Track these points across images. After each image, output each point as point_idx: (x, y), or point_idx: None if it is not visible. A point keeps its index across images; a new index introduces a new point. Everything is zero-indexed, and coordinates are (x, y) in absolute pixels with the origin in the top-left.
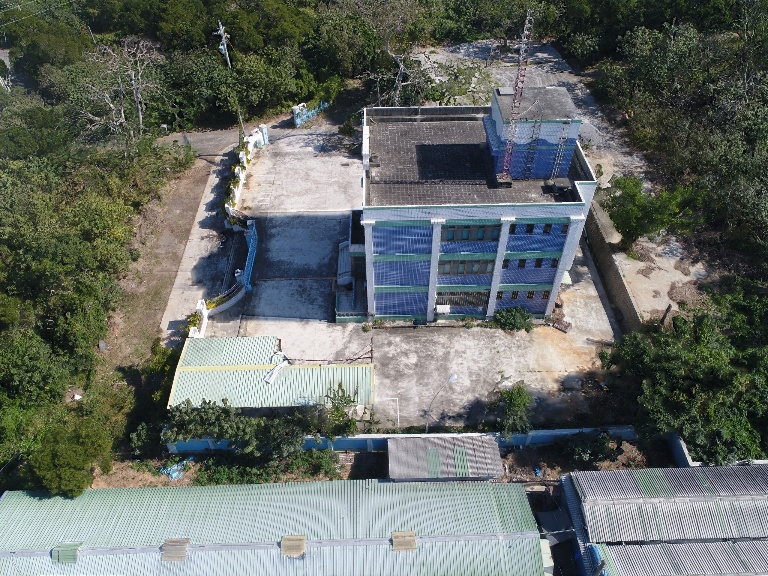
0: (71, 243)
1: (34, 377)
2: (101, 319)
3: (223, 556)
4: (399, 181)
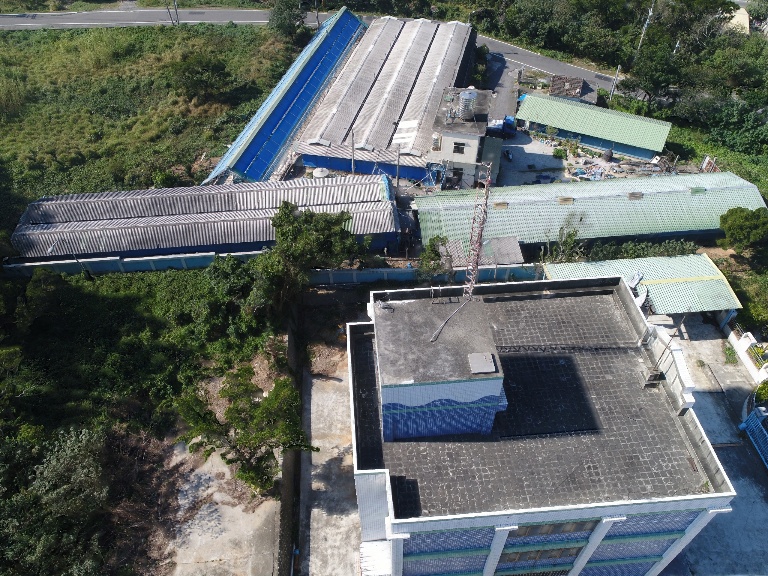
0: None
1: None
2: None
3: None
4: (600, 348)
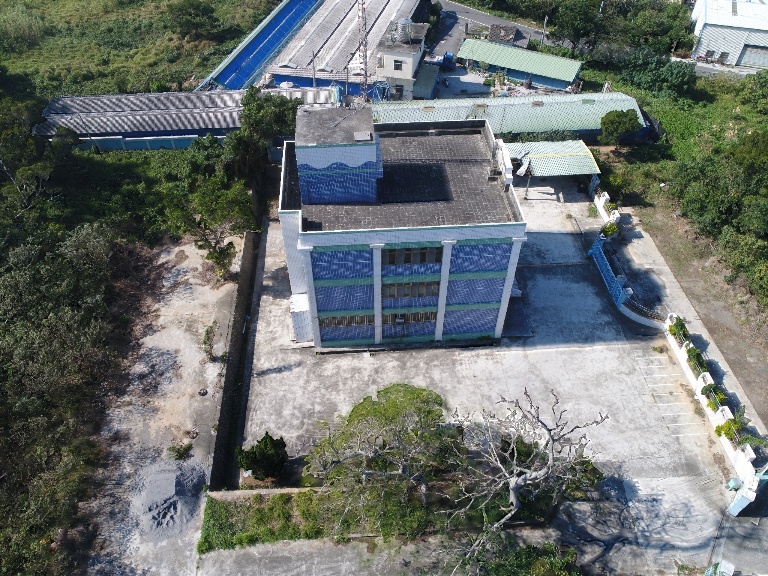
0: None
1: None
2: None
3: (513, 103)
4: (463, 161)
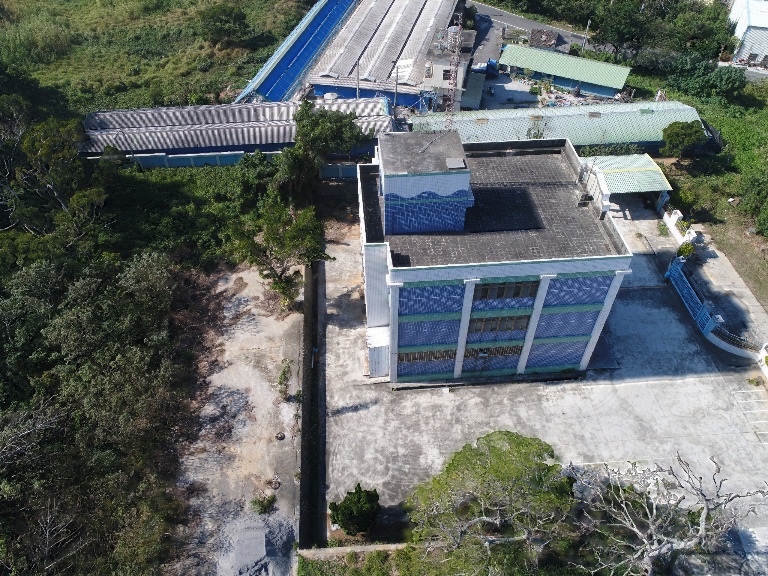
0: None
1: (761, 175)
2: (764, 217)
3: None
4: (548, 184)
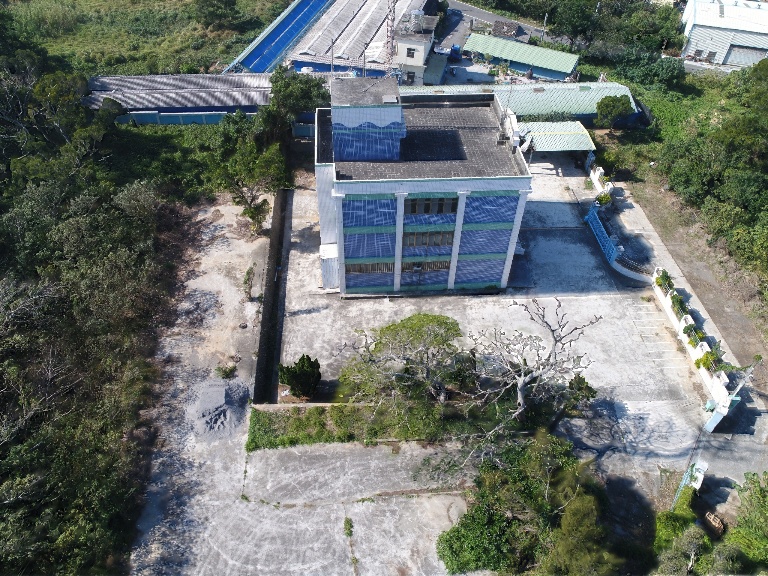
0: (767, 220)
1: None
2: None
3: (516, 89)
4: (475, 129)
